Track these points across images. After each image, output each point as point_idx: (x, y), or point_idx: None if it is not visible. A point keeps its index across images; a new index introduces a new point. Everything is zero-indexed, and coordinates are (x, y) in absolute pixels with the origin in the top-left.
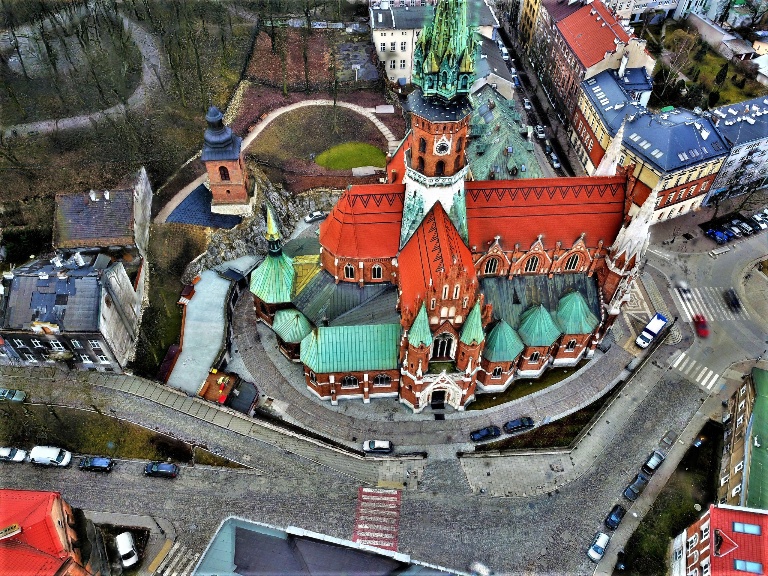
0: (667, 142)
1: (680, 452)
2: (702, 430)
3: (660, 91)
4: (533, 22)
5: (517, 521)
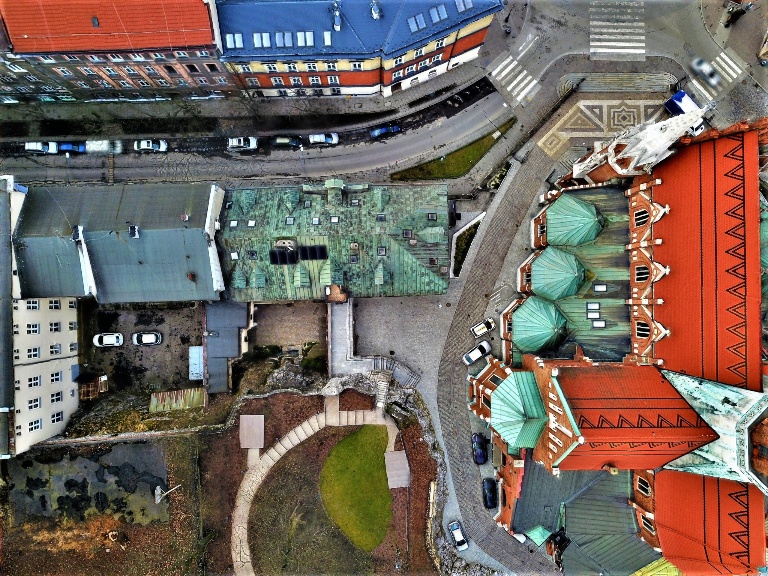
0: None
1: None
2: None
3: None
4: None
5: None
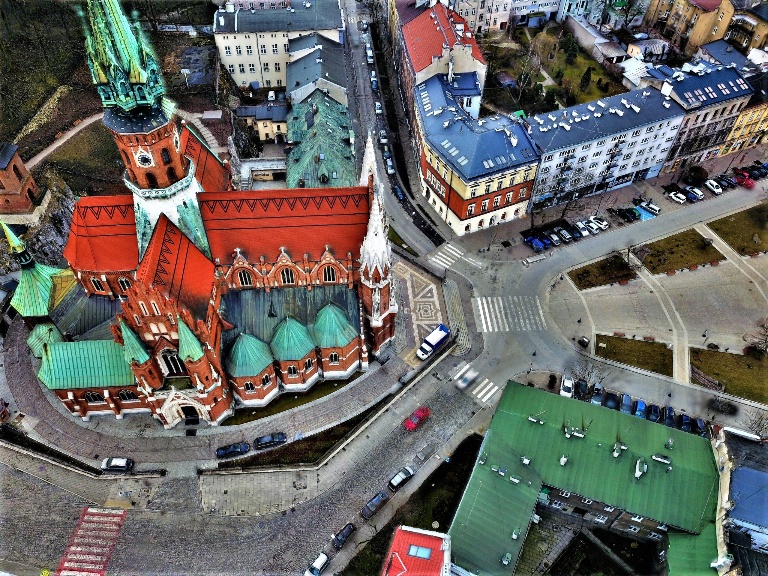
0: (473, 149)
1: (433, 467)
2: (459, 445)
3: (518, 95)
4: (393, 25)
5: (241, 541)
